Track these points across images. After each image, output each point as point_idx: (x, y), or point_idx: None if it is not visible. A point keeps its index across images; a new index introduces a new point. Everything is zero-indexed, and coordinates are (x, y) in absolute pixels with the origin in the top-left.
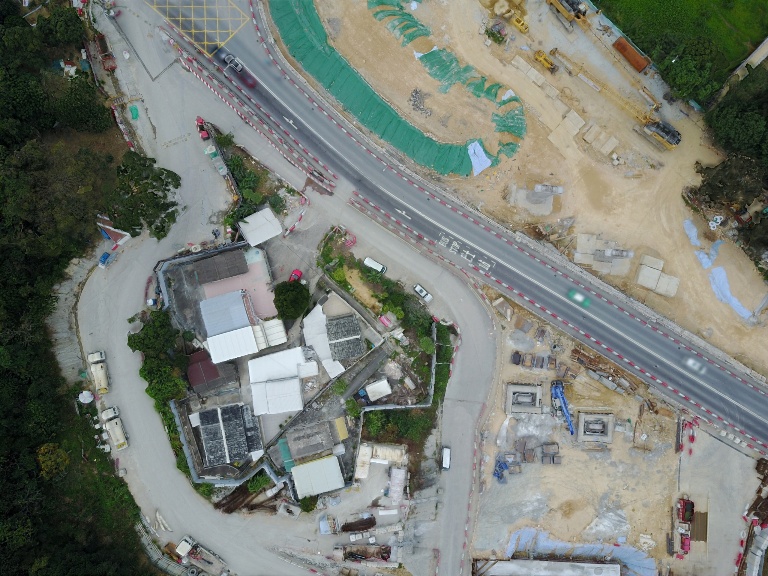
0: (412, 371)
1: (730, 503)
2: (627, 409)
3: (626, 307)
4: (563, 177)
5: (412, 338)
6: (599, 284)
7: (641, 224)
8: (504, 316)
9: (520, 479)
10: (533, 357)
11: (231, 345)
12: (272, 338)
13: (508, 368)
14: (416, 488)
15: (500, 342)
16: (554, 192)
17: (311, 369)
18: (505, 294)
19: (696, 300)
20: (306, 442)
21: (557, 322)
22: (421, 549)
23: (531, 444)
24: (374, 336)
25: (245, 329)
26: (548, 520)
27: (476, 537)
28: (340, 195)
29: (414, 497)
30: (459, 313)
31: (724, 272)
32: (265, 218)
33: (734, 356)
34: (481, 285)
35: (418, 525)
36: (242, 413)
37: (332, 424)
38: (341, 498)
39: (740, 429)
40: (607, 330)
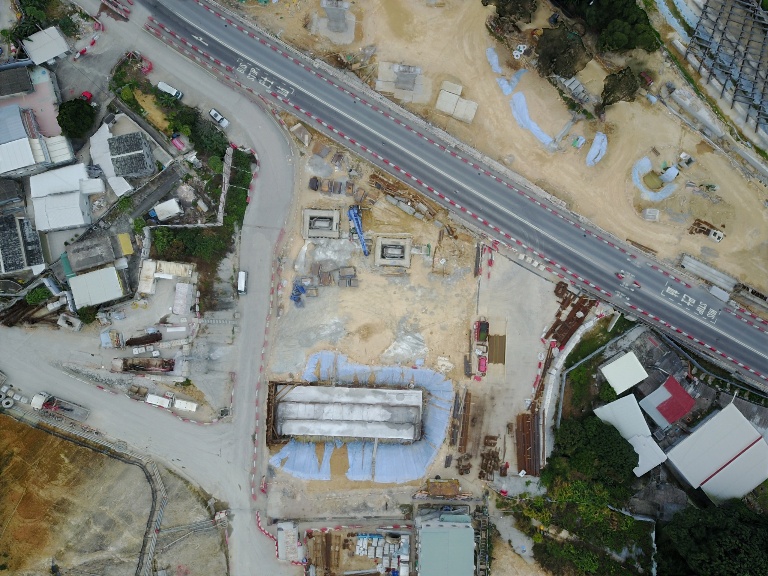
0: (205, 194)
1: (529, 326)
2: (427, 234)
3: (426, 133)
4: (364, 5)
5: (205, 161)
6: (399, 110)
7: (443, 52)
8: (302, 142)
9: (318, 303)
10: (330, 181)
11: (7, 157)
12: (55, 154)
13: (307, 194)
14: (207, 308)
15: (298, 168)
16: (339, 7)
17: (95, 185)
18: (303, 120)
19: (497, 127)
20: (85, 254)
21: (356, 148)
22: (216, 371)
23: (327, 267)
24: (163, 156)
25: (21, 140)
26: (346, 344)
27: (273, 361)
28: (135, 21)
29: (205, 317)
30: (257, 140)
31: (523, 97)
32: (43, 31)
33: (535, 182)
34: (279, 111)
35: (215, 349)
36: (22, 227)
37: (115, 239)
38: (126, 314)
39: (539, 253)
40: (407, 156)
